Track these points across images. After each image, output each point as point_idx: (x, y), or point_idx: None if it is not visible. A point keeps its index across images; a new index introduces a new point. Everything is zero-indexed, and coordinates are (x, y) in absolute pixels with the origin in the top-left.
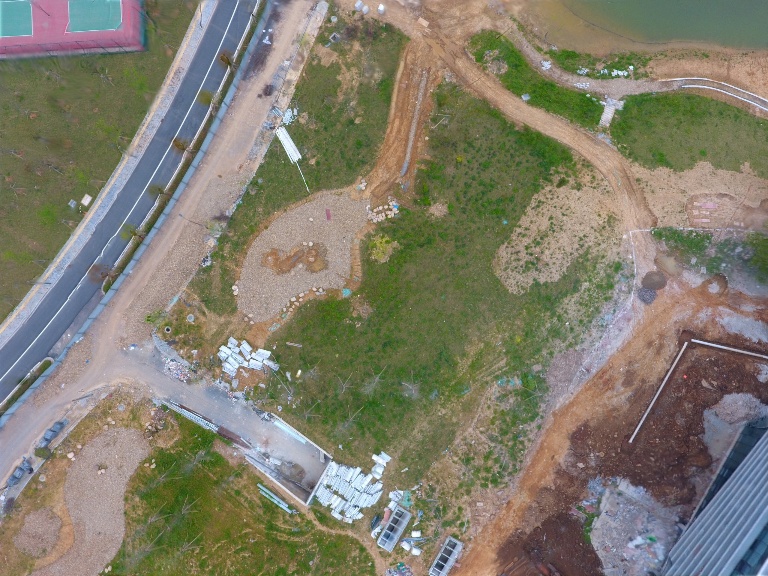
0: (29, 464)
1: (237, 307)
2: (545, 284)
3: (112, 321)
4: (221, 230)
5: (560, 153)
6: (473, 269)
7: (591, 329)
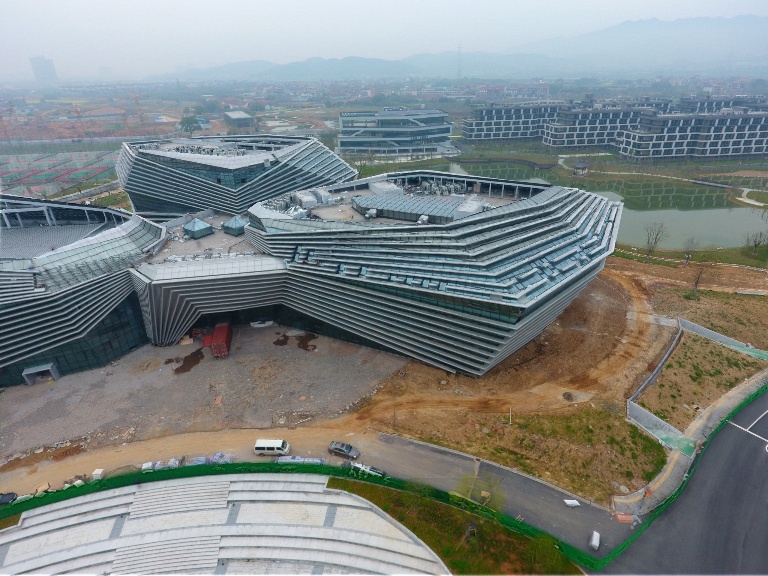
0: None
1: None
2: None
3: None
4: None
5: None
6: None
7: None
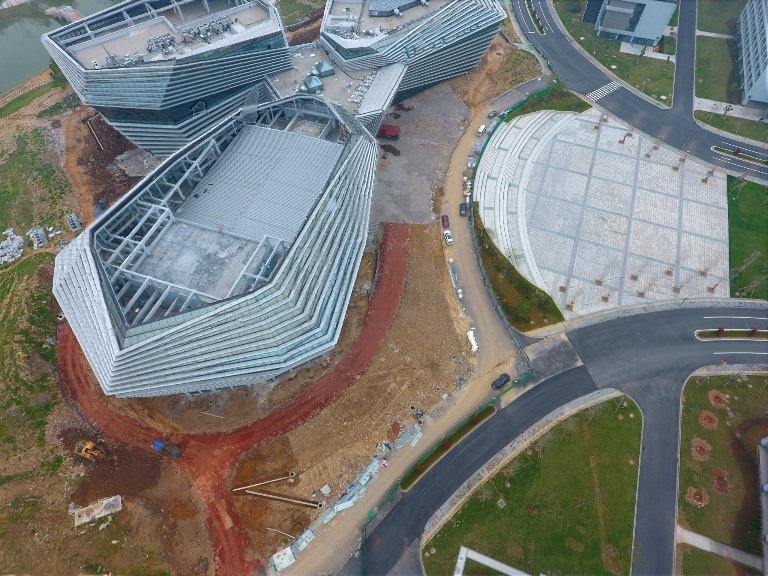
0: None
1: None
2: (14, 152)
3: None
4: None
5: None
6: None
7: (47, 145)
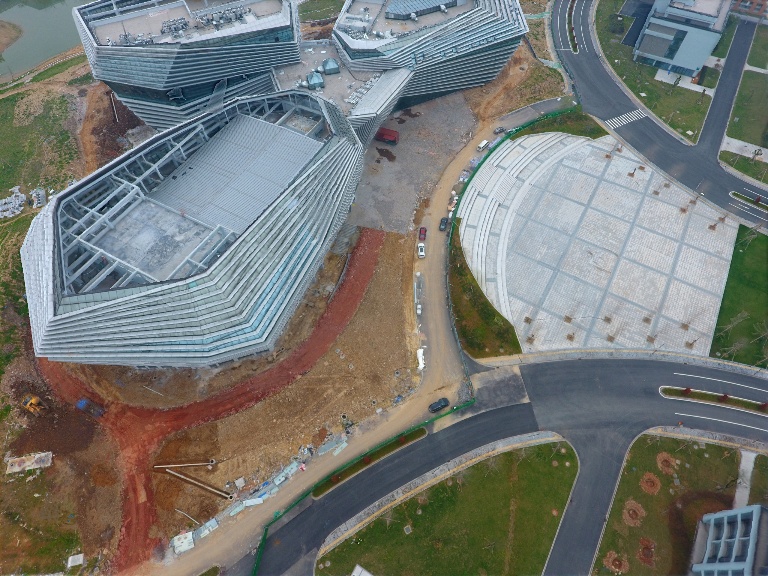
0: None
1: None
2: (39, 115)
3: None
4: None
5: (15, 95)
6: (7, 132)
7: None
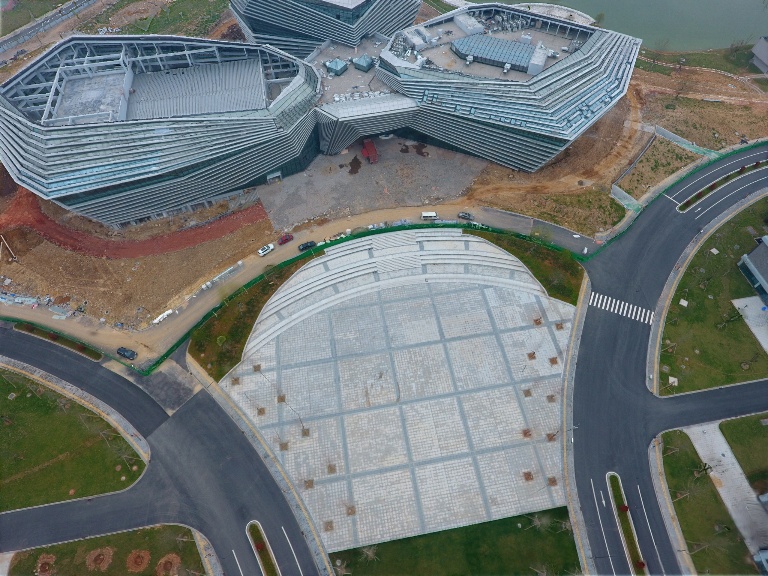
0: (6, 61)
1: (110, 23)
2: None
3: (58, 28)
4: (109, 7)
5: None
6: None
7: None
